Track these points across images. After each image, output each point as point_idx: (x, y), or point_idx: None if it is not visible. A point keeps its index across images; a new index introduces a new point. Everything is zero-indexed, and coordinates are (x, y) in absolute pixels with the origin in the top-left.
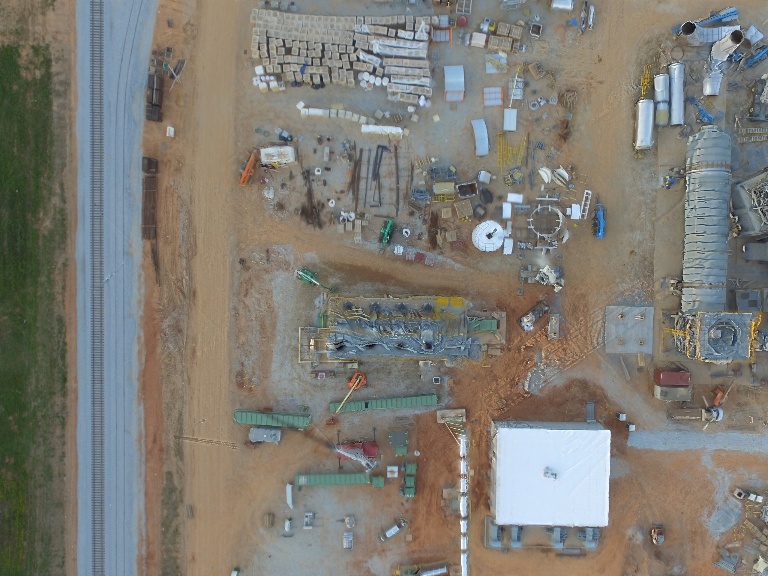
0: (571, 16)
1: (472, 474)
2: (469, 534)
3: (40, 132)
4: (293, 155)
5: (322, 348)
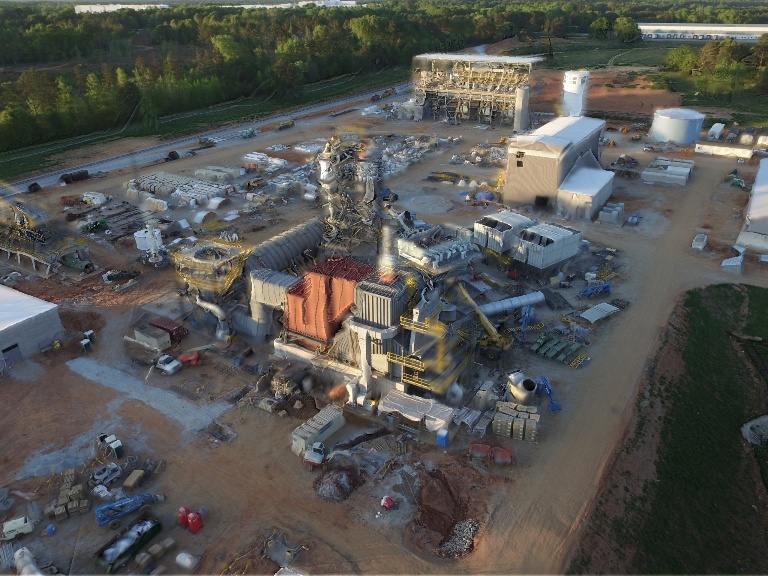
0: (315, 204)
1: None
2: None
3: (14, 173)
4: (102, 201)
5: None
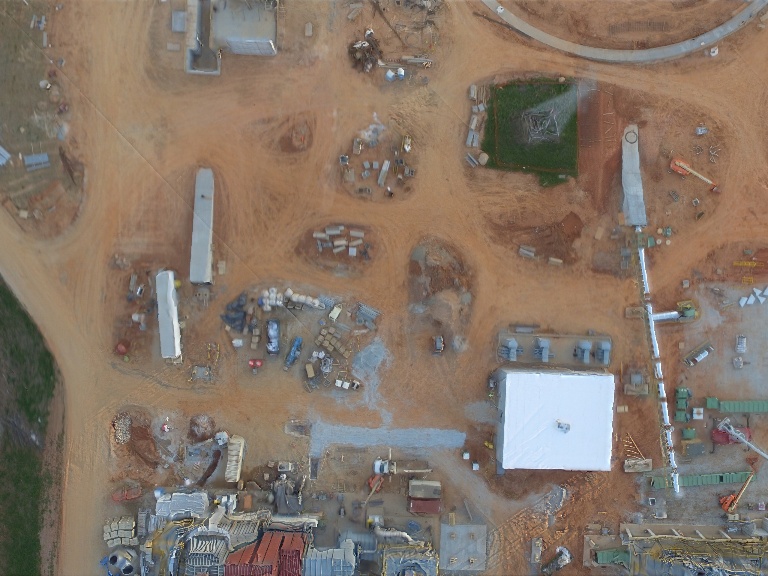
0: None
1: (620, 408)
2: (624, 348)
3: None
4: None
5: (766, 538)
